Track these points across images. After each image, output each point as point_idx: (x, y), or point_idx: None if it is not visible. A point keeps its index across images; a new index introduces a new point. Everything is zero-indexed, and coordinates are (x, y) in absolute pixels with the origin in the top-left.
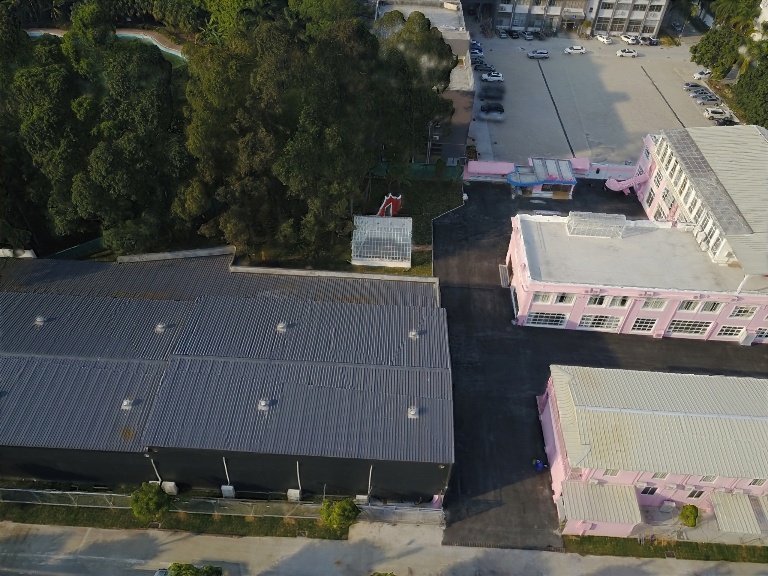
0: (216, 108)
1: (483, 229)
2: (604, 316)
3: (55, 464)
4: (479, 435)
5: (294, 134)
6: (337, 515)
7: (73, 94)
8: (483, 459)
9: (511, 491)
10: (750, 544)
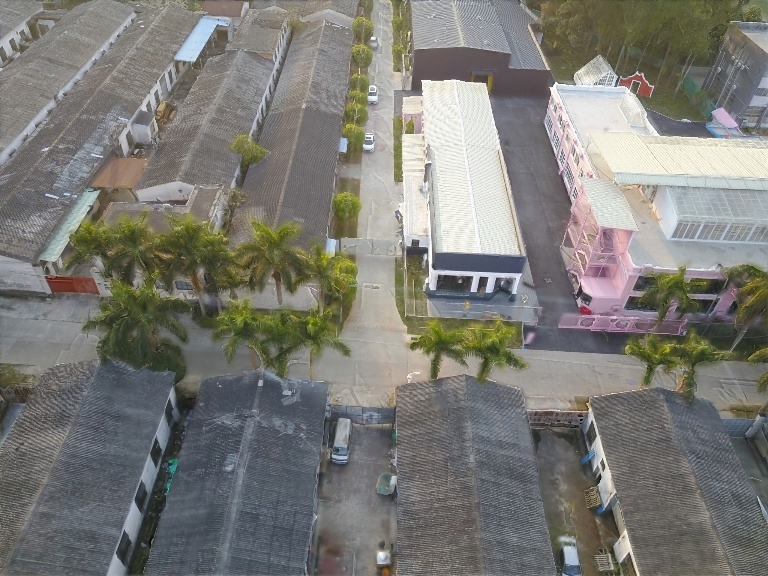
0: None
1: None
2: None
3: None
4: None
5: None
6: (394, 46)
7: None
8: None
9: None
10: None
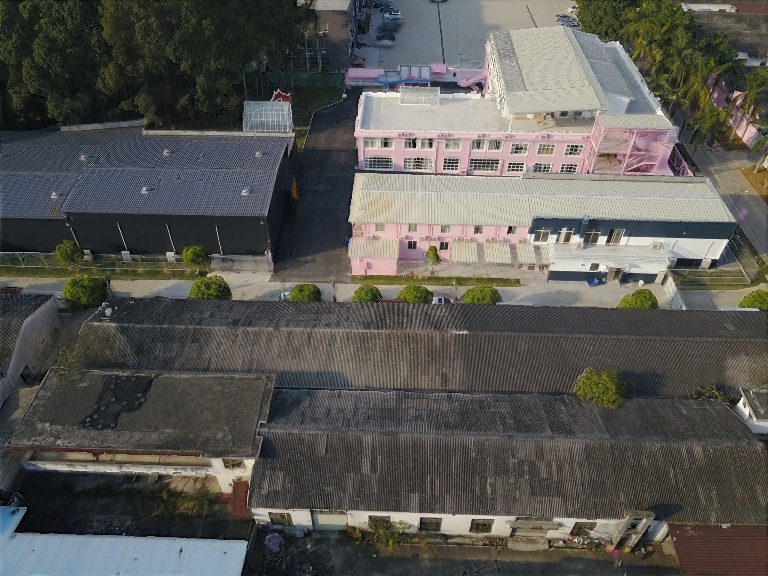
0: (120, 5)
1: (353, 116)
2: (420, 158)
3: (8, 237)
4: (310, 228)
5: (179, 24)
6: (190, 252)
7: (20, 0)
8: (309, 240)
9: (324, 255)
10: (480, 277)
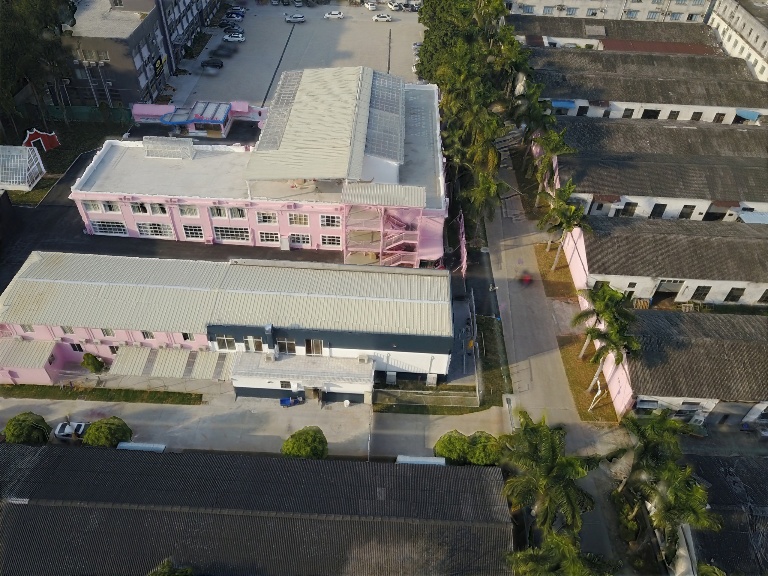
0: None
1: None
2: (156, 224)
3: None
4: None
5: None
6: None
7: None
8: None
9: None
10: (155, 390)
